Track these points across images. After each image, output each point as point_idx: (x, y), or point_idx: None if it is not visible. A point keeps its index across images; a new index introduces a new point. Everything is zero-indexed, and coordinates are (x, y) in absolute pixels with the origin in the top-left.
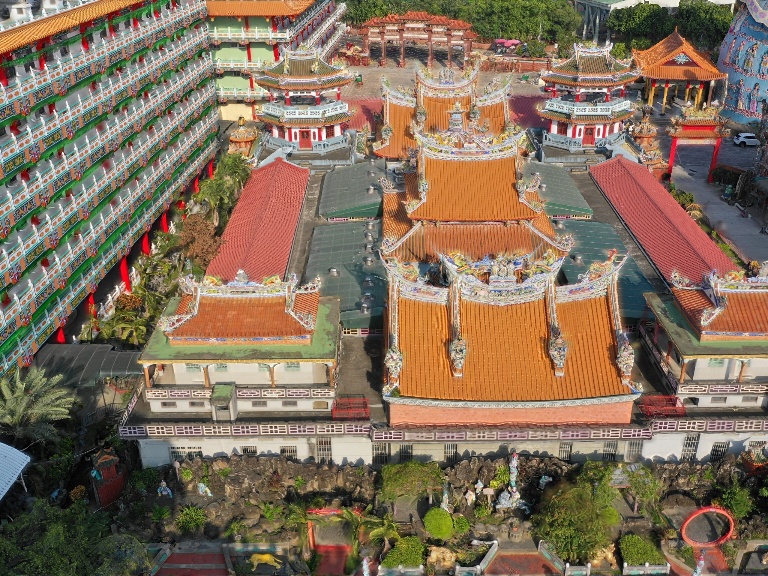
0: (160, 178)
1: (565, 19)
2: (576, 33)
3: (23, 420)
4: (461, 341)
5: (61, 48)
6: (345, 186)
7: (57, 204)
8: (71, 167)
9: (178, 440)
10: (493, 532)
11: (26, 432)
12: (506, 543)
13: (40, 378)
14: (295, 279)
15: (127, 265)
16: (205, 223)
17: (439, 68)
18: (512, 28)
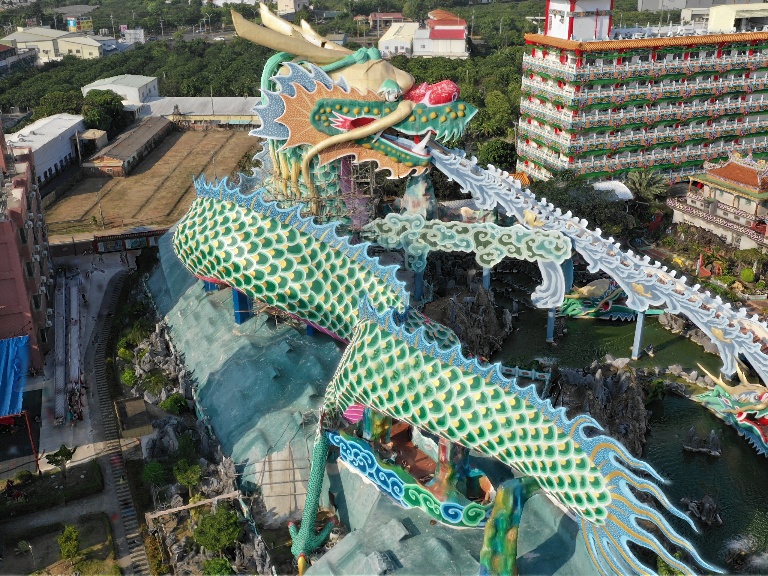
0: None
1: None
2: None
3: None
4: None
5: None
6: None
7: None
8: (742, 106)
9: (687, 216)
10: None
11: None
12: None
13: None
14: None
15: None
16: None
17: None
18: None
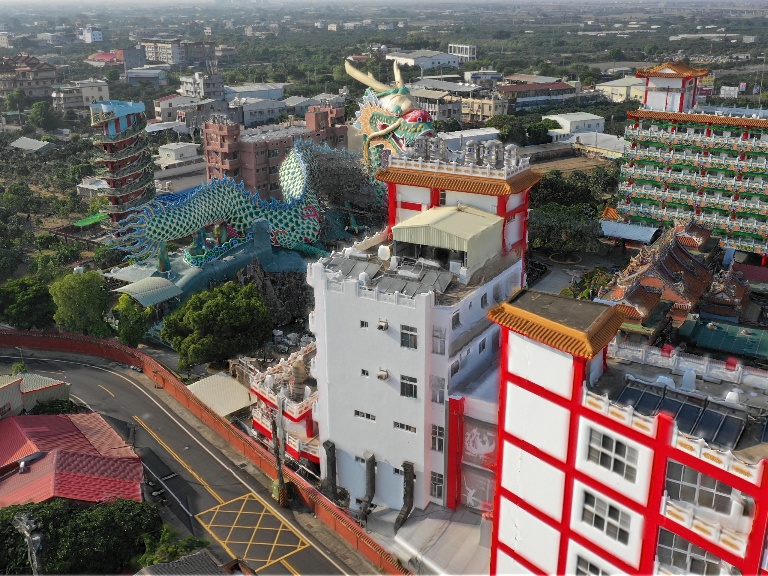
0: None
1: None
2: None
3: None
4: None
5: None
6: None
7: None
8: None
9: None
10: None
11: None
12: None
13: None
14: None
15: None
16: None
17: None
18: None
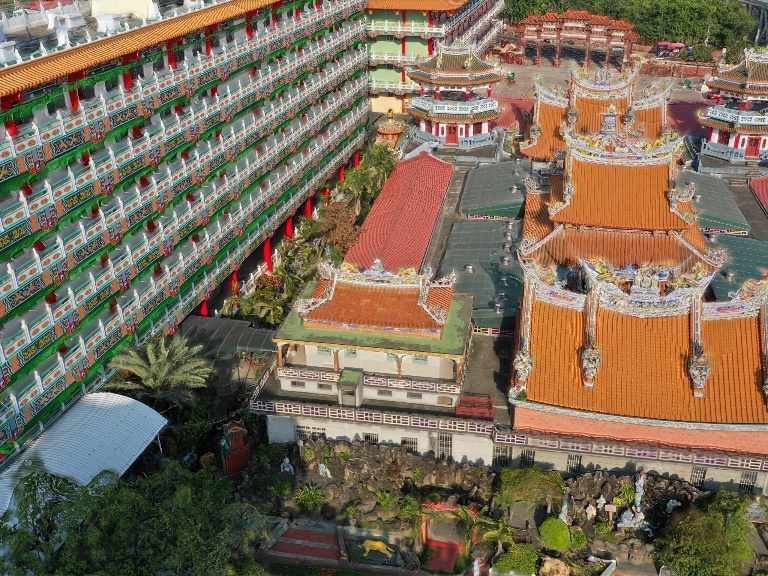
0: (308, 165)
1: (737, 23)
2: (748, 38)
3: (164, 384)
4: (595, 350)
5: (227, 35)
6: (488, 184)
7: (211, 183)
8: (227, 149)
9: (304, 419)
10: (612, 551)
11: (166, 396)
12: (625, 564)
13: (182, 346)
14: (430, 272)
15: (270, 246)
16: (347, 211)
17: (595, 69)
18: (677, 30)
